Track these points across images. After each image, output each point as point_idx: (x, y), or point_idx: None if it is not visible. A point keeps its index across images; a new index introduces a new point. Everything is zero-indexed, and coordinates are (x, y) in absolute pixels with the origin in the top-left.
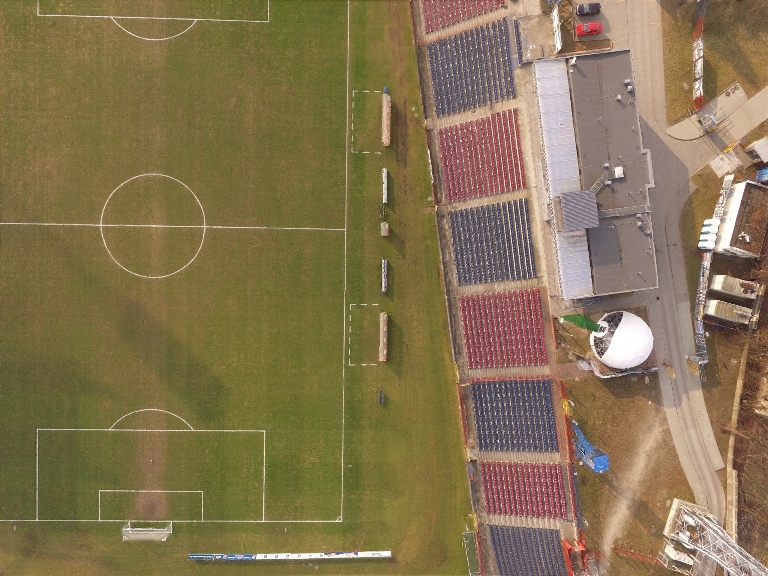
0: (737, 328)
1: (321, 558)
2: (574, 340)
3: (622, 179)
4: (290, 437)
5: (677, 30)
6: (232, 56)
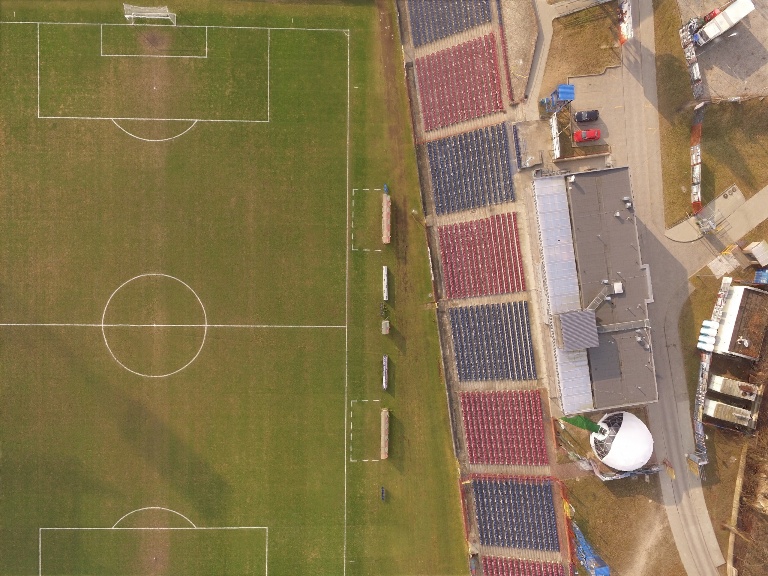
0: (736, 427)
1: None
2: (574, 441)
3: (621, 294)
4: (292, 533)
5: (675, 135)
6: (232, 156)
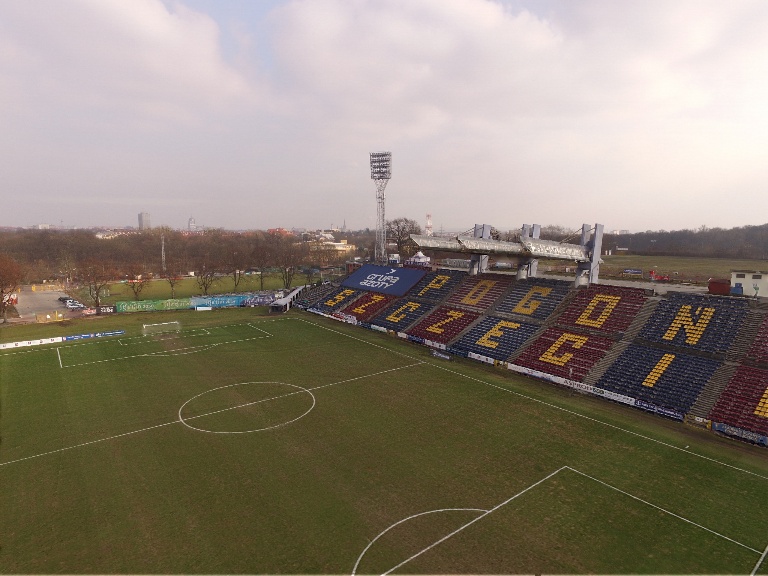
0: None
1: None
2: None
3: None
4: None
5: None
6: None
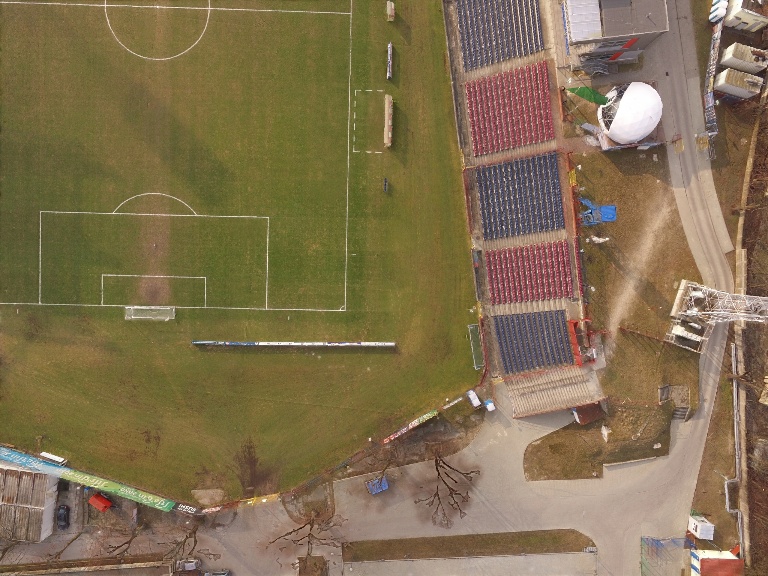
0: None
1: (324, 347)
2: (582, 114)
3: None
4: (294, 224)
5: None
6: None
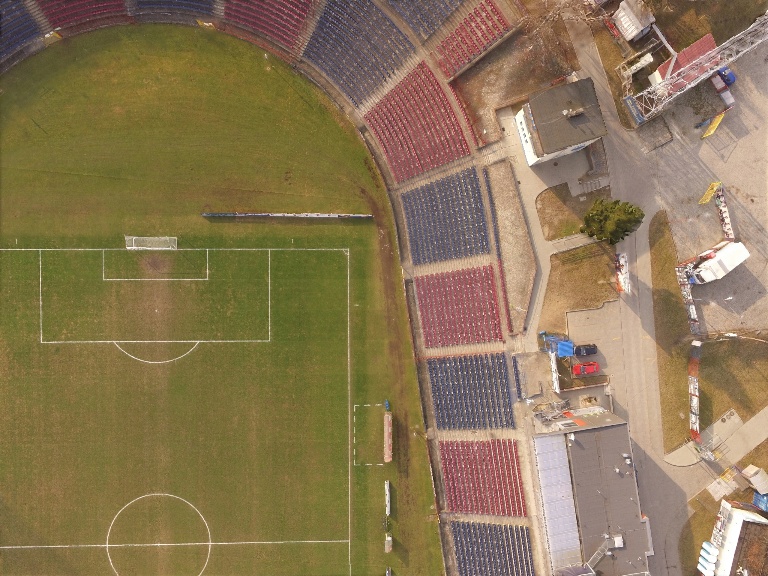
0: None
1: None
2: None
3: None
4: None
5: (673, 365)
6: (234, 376)
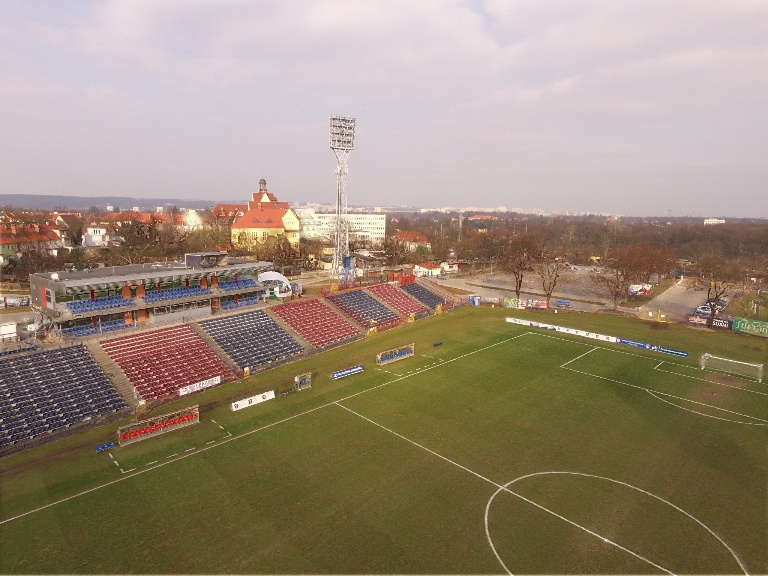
0: None
1: None
2: None
3: None
4: None
5: None
6: None
